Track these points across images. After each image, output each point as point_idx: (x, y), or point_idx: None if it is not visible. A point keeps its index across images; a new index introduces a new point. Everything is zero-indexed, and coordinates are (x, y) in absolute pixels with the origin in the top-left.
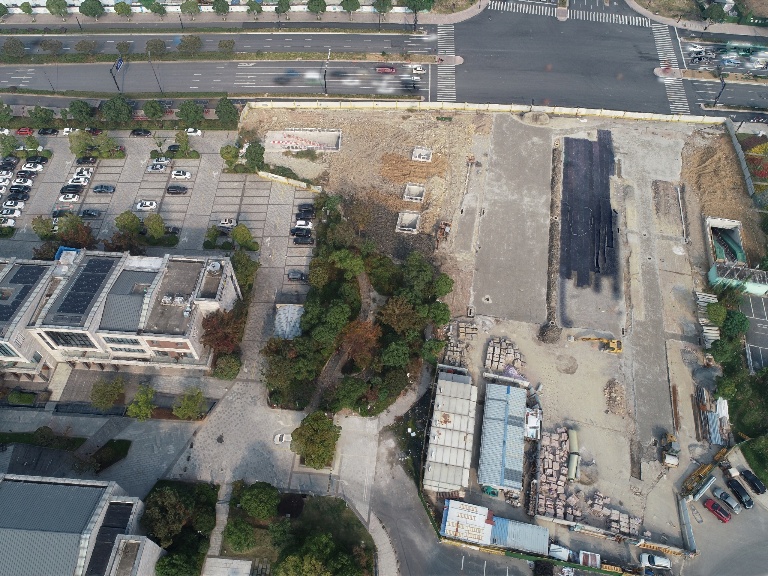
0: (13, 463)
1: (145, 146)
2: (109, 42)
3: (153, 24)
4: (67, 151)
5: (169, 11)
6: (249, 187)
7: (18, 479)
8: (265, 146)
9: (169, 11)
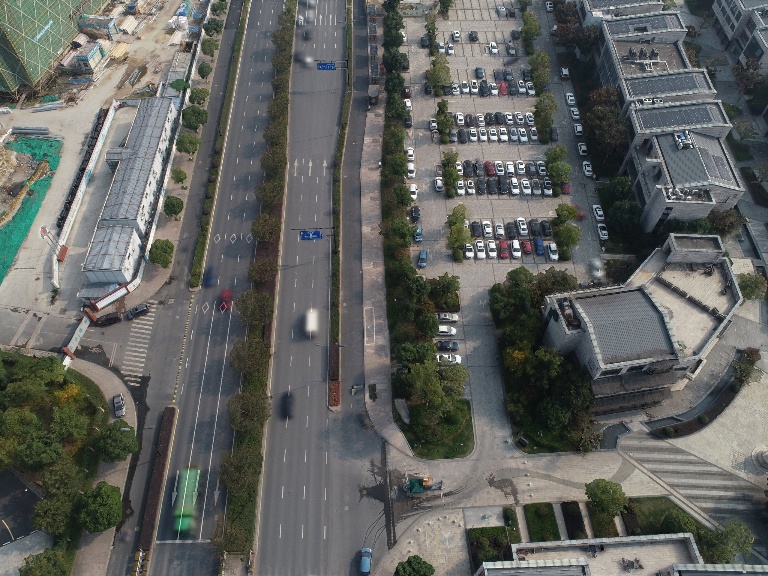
0: (712, 65)
1: (421, 61)
2: (246, 114)
3: (214, 88)
4: (432, 105)
5: (193, 77)
6: (462, 7)
7: (744, 6)
8: (417, 1)
9: (193, 77)
